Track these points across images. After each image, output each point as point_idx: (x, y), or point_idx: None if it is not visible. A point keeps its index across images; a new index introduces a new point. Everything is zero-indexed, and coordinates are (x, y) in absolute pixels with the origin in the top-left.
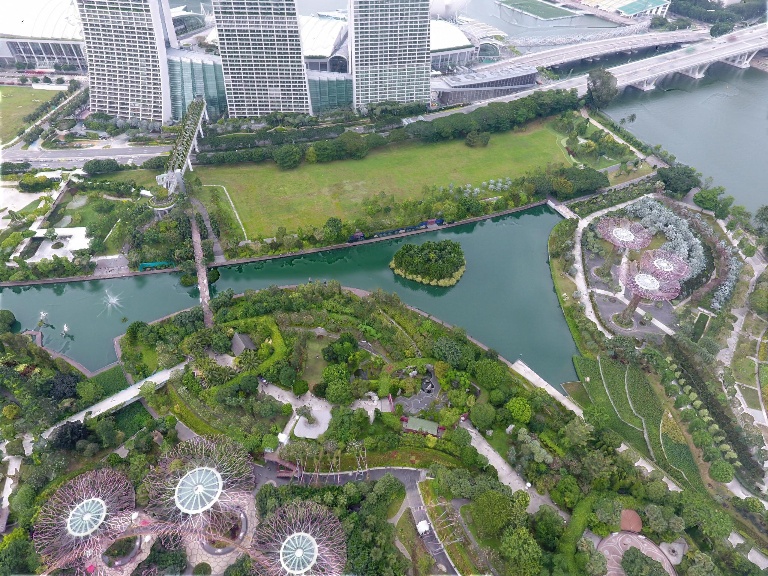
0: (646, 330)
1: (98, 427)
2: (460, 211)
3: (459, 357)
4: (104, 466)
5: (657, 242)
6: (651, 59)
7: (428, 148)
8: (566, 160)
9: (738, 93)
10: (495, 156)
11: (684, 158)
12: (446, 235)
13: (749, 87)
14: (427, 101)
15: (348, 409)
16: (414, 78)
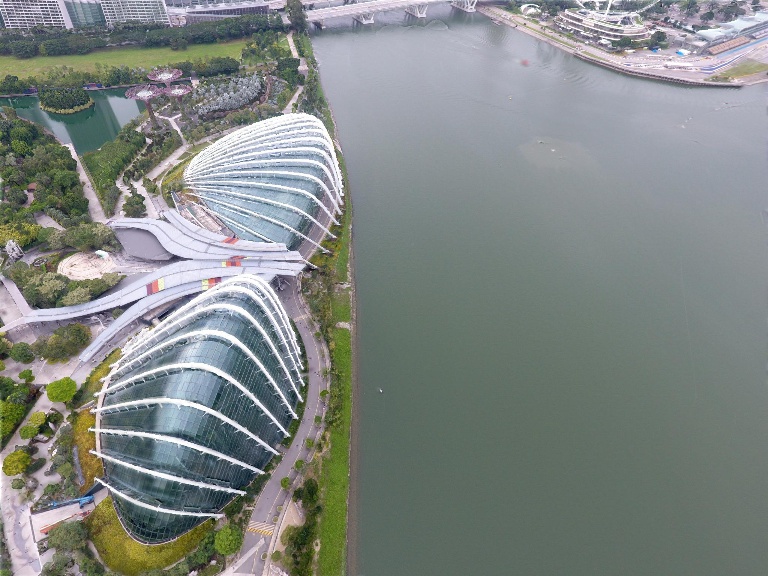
0: (165, 132)
1: None
2: (110, 77)
3: (7, 127)
4: None
5: None
6: (380, 1)
7: (141, 50)
8: (235, 58)
9: (446, 28)
10: (185, 55)
11: (333, 61)
12: (112, 98)
13: (475, 28)
14: (167, 23)
15: None
16: (150, 3)
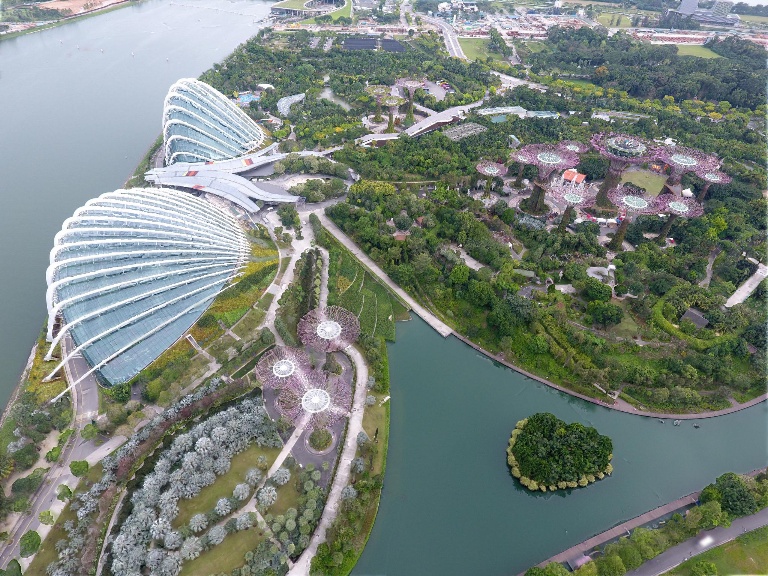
0: None
1: (730, 261)
2: (540, 569)
3: None
4: (704, 253)
5: (195, 512)
6: None
7: None
8: None
9: None
10: None
11: None
12: None
13: None
14: None
15: (579, 276)
16: None
